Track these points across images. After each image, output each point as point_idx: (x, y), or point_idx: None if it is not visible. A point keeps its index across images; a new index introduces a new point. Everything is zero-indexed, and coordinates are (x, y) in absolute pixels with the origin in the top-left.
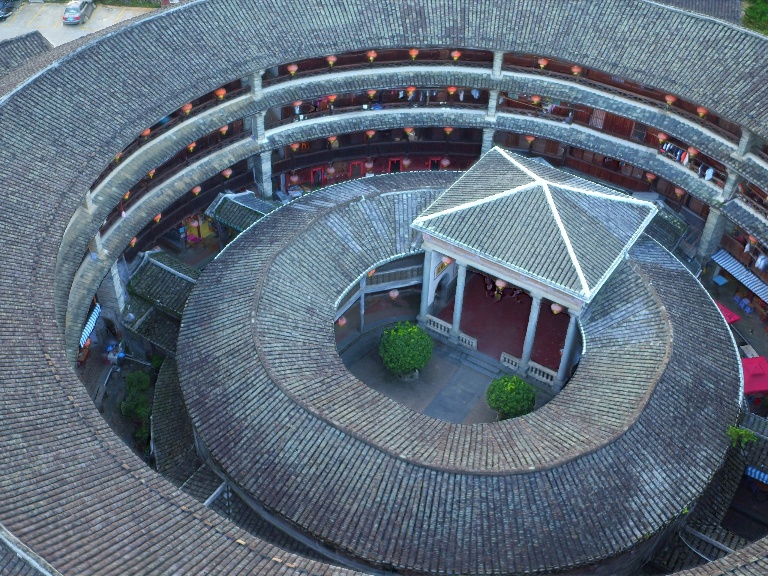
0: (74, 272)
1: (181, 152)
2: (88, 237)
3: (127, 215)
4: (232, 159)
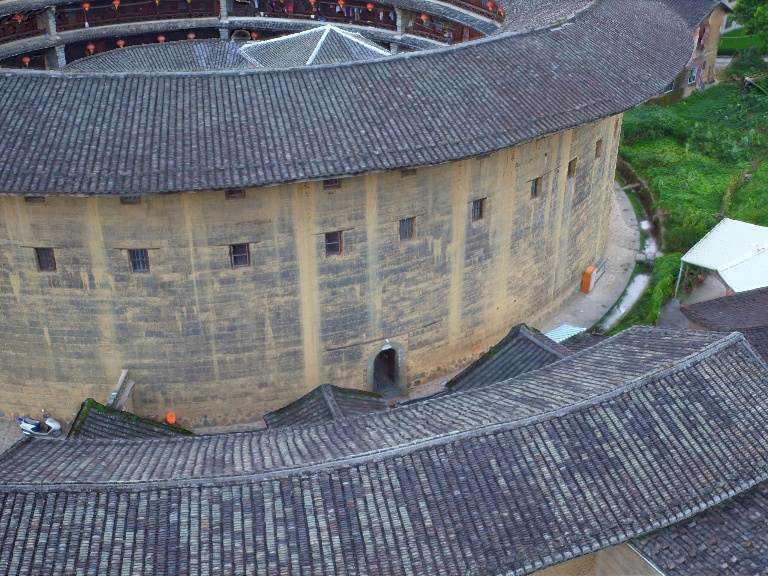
0: (0, 14)
1: (156, 8)
2: (30, 6)
3: (92, 29)
4: (194, 25)
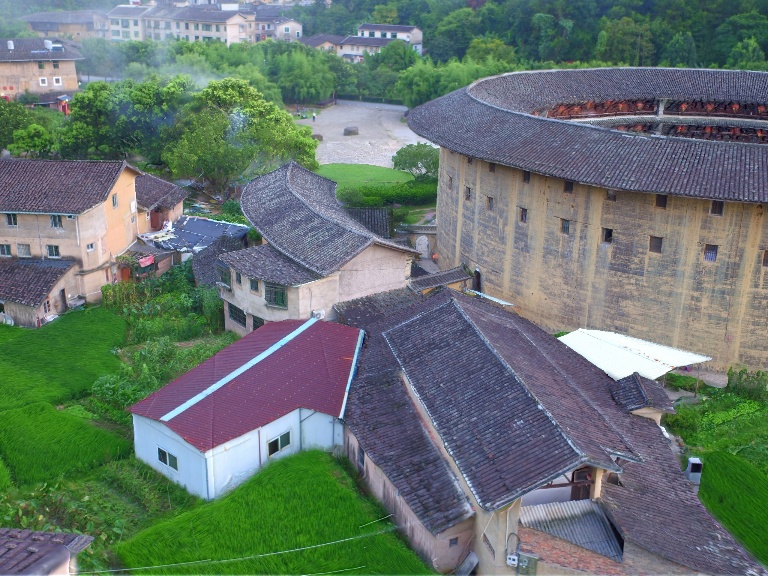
0: (764, 127)
1: None
2: None
3: None
4: None
